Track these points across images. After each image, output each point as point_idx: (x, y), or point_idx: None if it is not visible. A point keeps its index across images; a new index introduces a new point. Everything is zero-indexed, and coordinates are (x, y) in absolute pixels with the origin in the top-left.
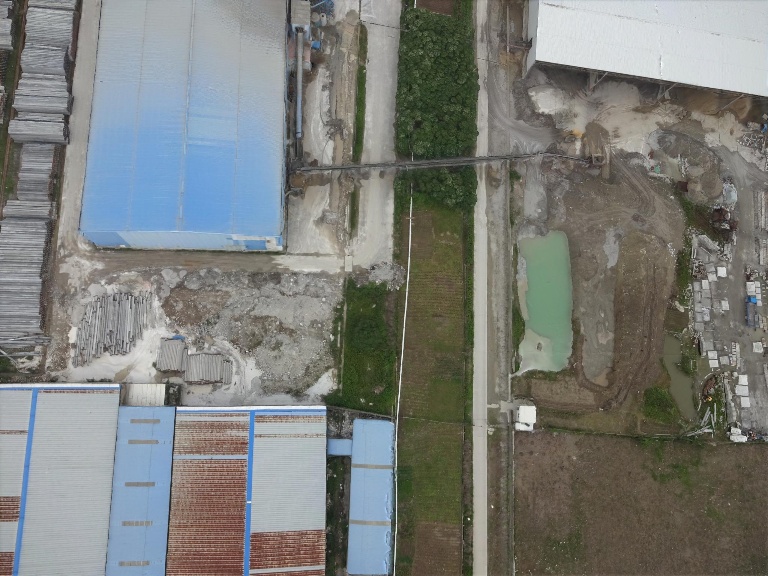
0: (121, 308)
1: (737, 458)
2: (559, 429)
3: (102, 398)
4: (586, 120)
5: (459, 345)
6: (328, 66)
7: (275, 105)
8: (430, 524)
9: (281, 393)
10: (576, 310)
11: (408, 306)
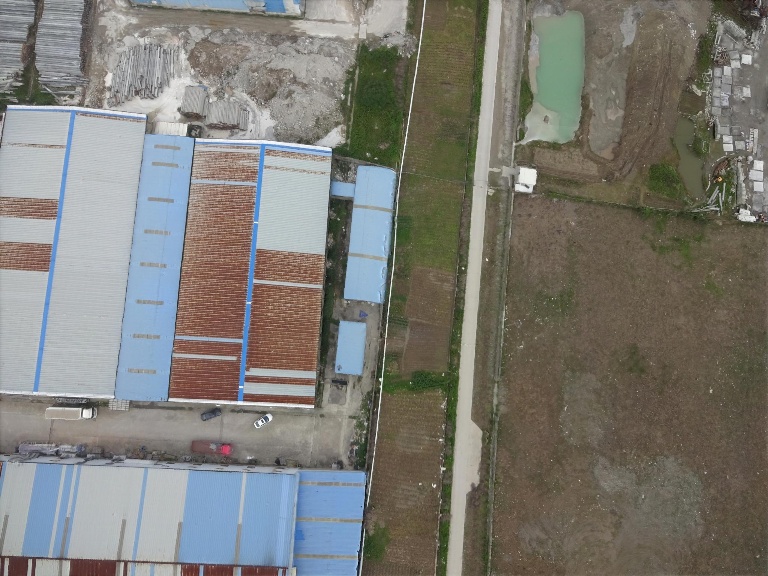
0: (151, 56)
1: (743, 238)
2: (559, 194)
3: (130, 125)
4: None
5: (465, 112)
6: None
7: None
8: (425, 269)
9: (292, 142)
10: (586, 86)
11: (418, 73)
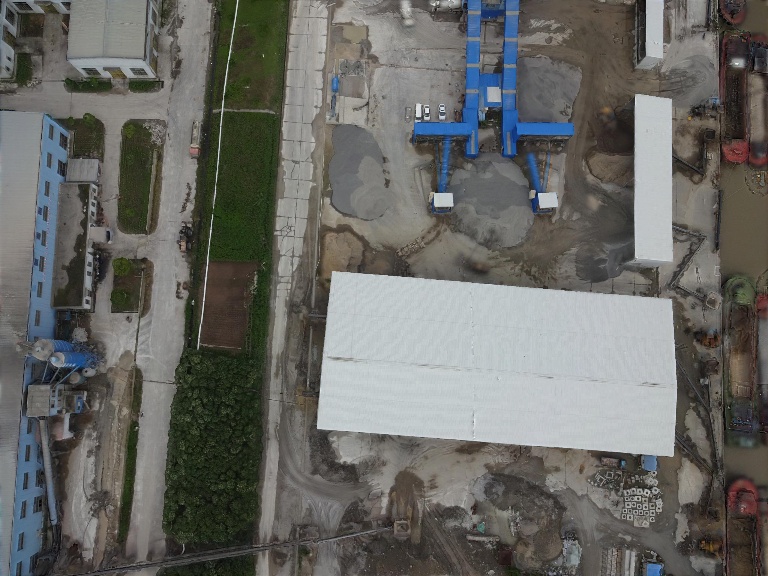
0: None
1: None
2: None
3: None
4: (397, 468)
5: None
6: (95, 425)
7: (2, 523)
8: None
9: None
10: None
11: None
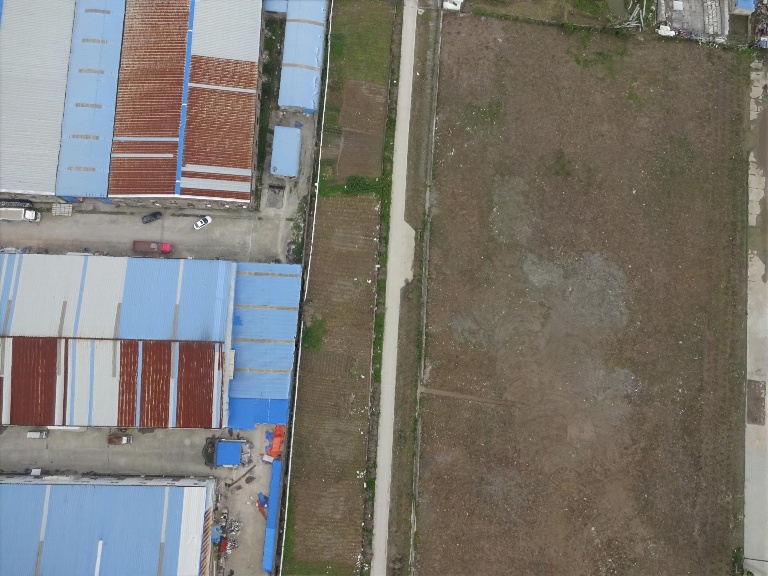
0: None
1: (664, 53)
2: (486, 12)
3: None
4: None
5: None
6: None
7: None
8: (358, 82)
9: None
10: None
11: None
